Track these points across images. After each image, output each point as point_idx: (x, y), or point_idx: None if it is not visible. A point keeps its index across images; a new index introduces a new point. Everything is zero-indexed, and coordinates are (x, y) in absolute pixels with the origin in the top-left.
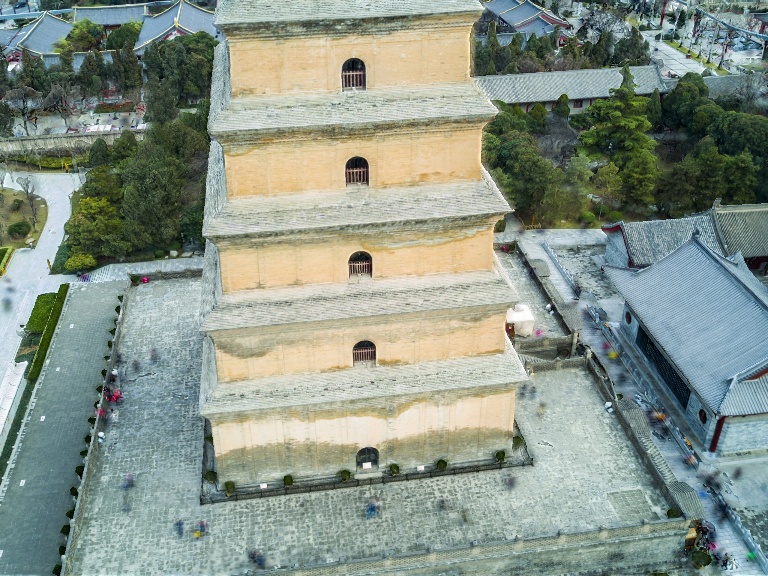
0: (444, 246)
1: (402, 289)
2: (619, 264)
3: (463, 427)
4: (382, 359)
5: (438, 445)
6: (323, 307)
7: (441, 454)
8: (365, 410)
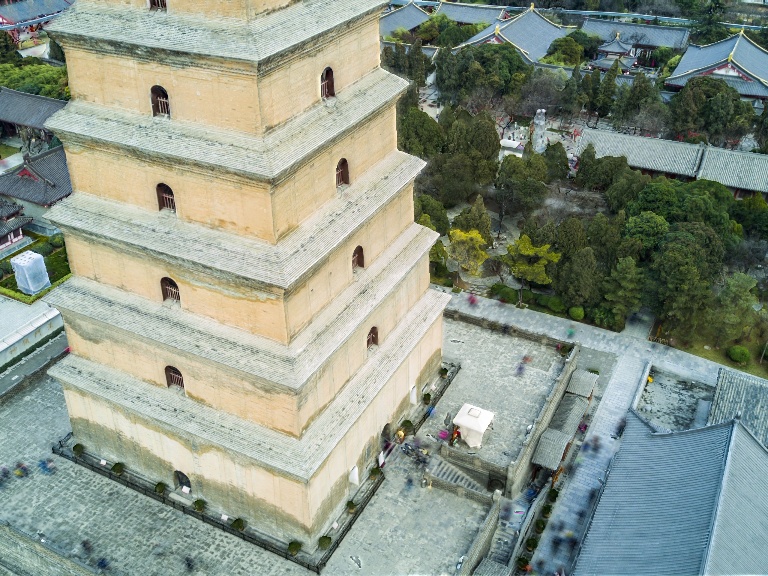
0: (239, 301)
1: (201, 329)
2: None
3: (261, 497)
4: (190, 391)
5: (241, 503)
6: (133, 318)
7: (245, 514)
8: (174, 434)
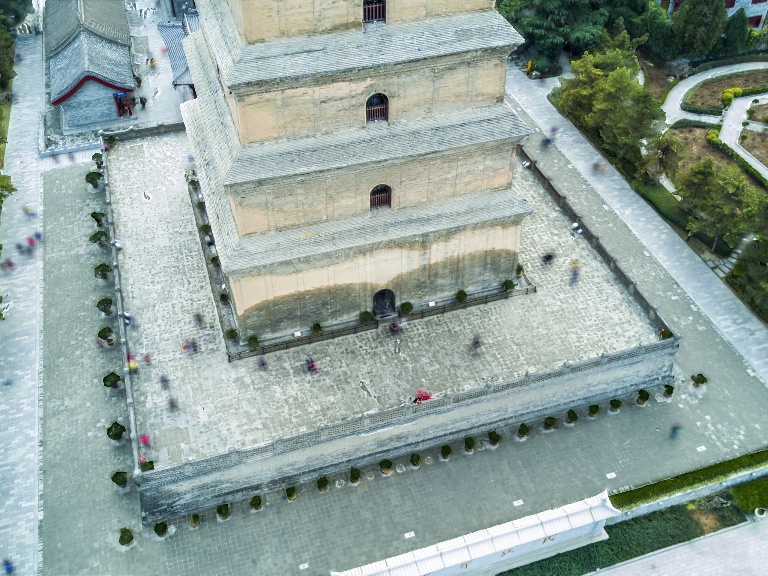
0: None
1: None
2: (102, 111)
3: None
4: None
5: None
6: None
7: None
8: None
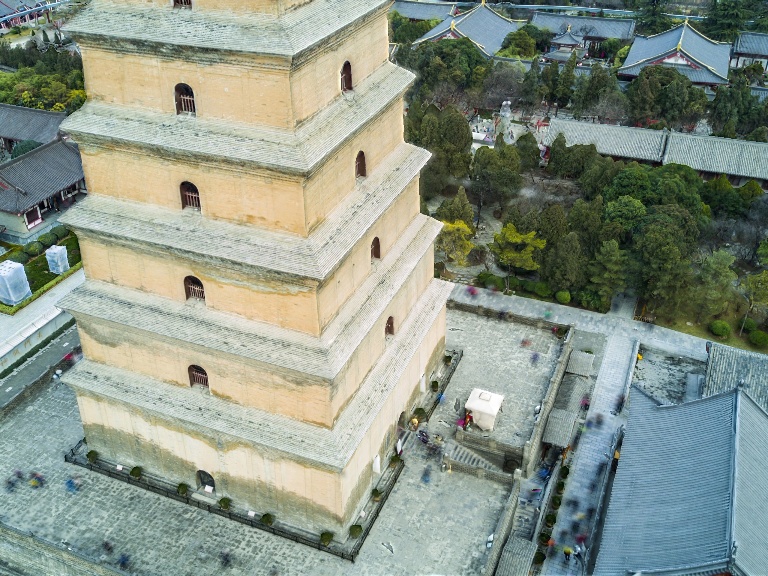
0: (268, 296)
1: (228, 326)
2: None
3: (290, 490)
4: (215, 389)
5: (268, 498)
6: (155, 319)
7: (272, 508)
8: (198, 433)
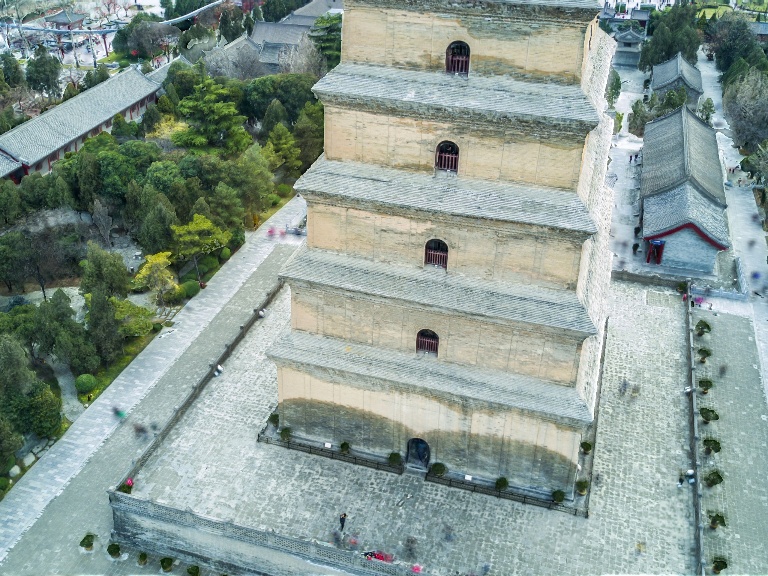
0: None
1: None
2: None
3: None
4: None
5: None
6: (598, 261)
7: None
8: None
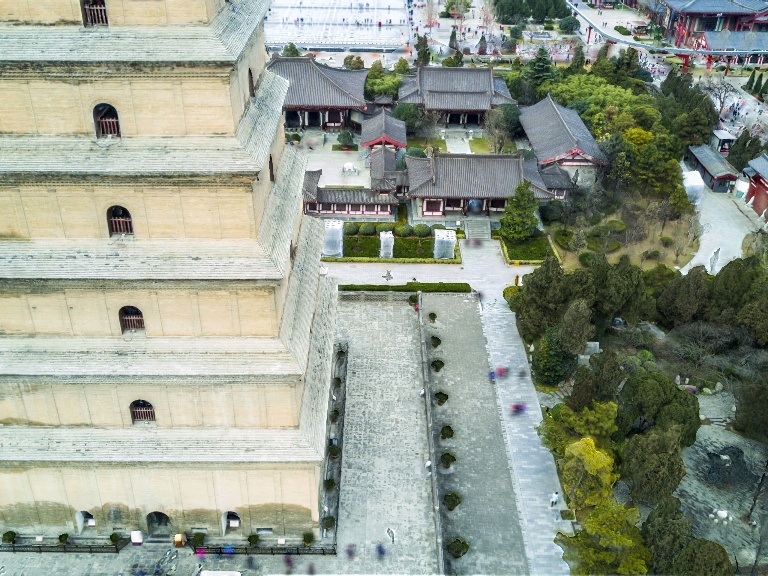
0: None
1: None
2: None
3: None
4: None
5: None
6: None
7: None
8: None
